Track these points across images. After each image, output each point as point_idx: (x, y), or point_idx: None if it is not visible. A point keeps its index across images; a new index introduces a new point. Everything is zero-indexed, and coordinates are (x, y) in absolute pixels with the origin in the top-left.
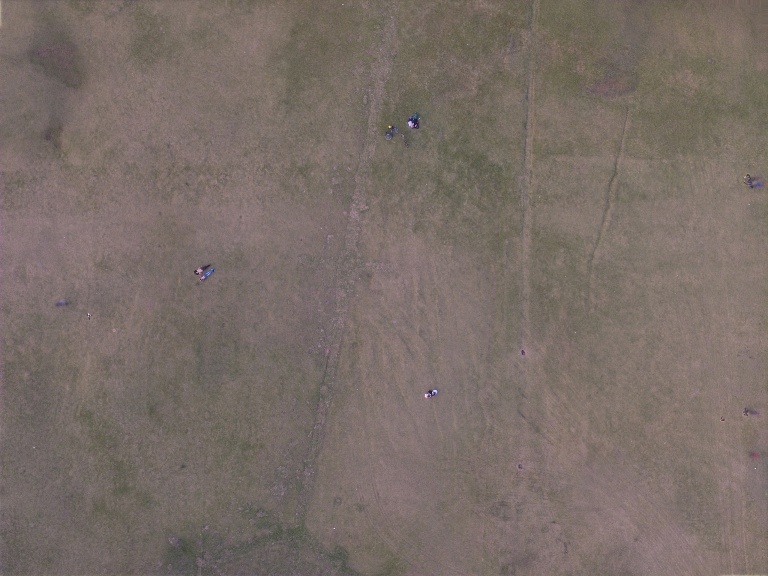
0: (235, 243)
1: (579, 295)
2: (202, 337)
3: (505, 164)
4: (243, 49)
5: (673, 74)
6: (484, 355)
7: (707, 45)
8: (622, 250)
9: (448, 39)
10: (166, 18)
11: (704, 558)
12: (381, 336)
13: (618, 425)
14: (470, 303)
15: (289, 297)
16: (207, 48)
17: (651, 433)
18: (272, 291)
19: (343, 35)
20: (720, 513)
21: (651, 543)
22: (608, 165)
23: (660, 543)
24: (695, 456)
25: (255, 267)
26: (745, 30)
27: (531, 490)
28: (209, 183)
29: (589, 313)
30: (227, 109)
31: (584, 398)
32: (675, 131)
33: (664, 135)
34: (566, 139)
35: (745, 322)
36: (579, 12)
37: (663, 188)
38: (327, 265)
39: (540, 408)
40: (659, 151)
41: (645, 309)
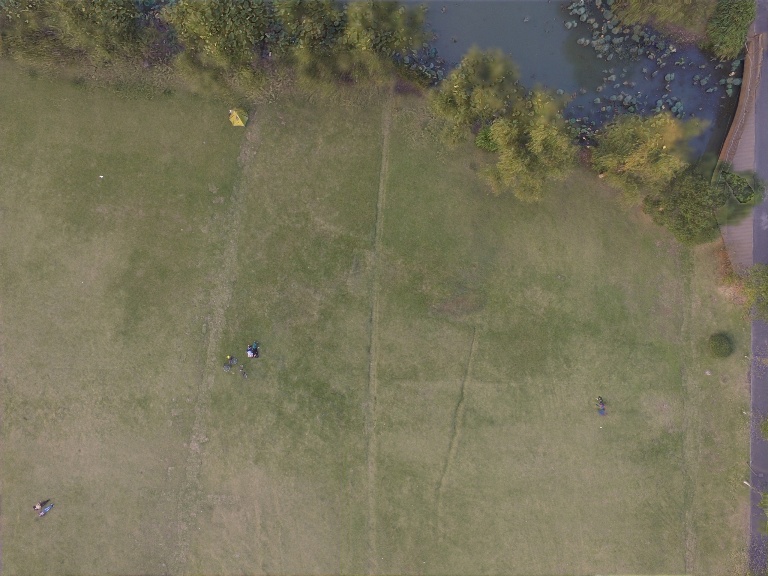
0: (74, 477)
1: (427, 524)
2: (42, 574)
3: (348, 391)
4: (81, 279)
5: (522, 292)
6: None
7: (557, 260)
8: (470, 477)
9: (289, 263)
10: (3, 249)
11: None
12: (223, 571)
13: None
14: (314, 535)
15: (130, 531)
16: (44, 279)
17: None
18: (113, 525)
19: (182, 261)
20: None
21: None
22: (454, 390)
23: None
24: None
25: (95, 501)
26: (596, 243)
27: None
28: (47, 417)
29: (438, 542)
30: (64, 341)
31: None
32: (523, 352)
33: (512, 357)
34: (411, 363)
35: (600, 550)
36: (424, 230)
37: (511, 413)
38: (168, 498)
39: None
40: (507, 374)
41: (495, 538)
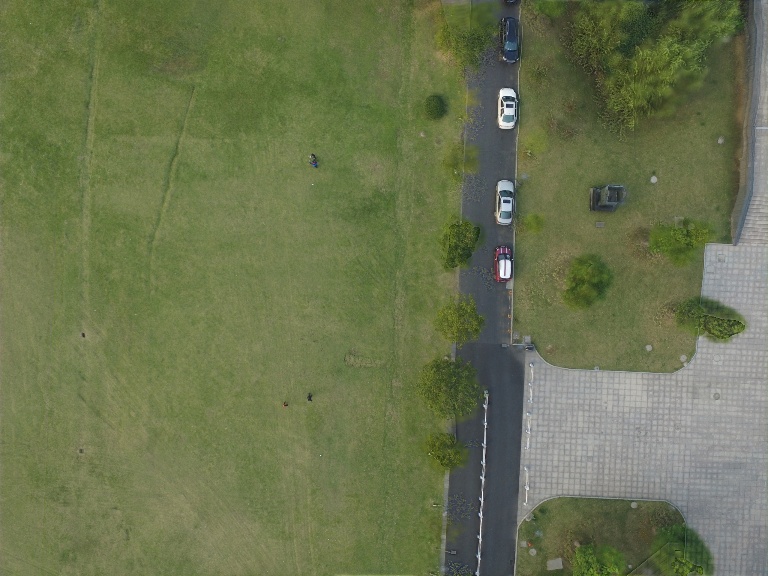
0: None
1: (139, 277)
2: None
3: (64, 144)
4: None
5: (242, 52)
6: (43, 338)
7: (278, 23)
8: (182, 231)
9: (11, 18)
10: None
11: (267, 547)
12: None
13: (179, 410)
14: (28, 285)
15: None
16: None
17: (212, 418)
18: None
19: None
20: (284, 501)
21: (212, 531)
22: (169, 145)
23: (221, 531)
24: (257, 442)
25: None
26: (319, 7)
27: (92, 475)
28: None
29: (150, 295)
30: None
31: (145, 382)
32: (239, 110)
33: (228, 114)
34: (128, 119)
35: (308, 305)
36: None
37: (224, 168)
38: None
39: (101, 392)
40: (221, 130)
41: (206, 291)
